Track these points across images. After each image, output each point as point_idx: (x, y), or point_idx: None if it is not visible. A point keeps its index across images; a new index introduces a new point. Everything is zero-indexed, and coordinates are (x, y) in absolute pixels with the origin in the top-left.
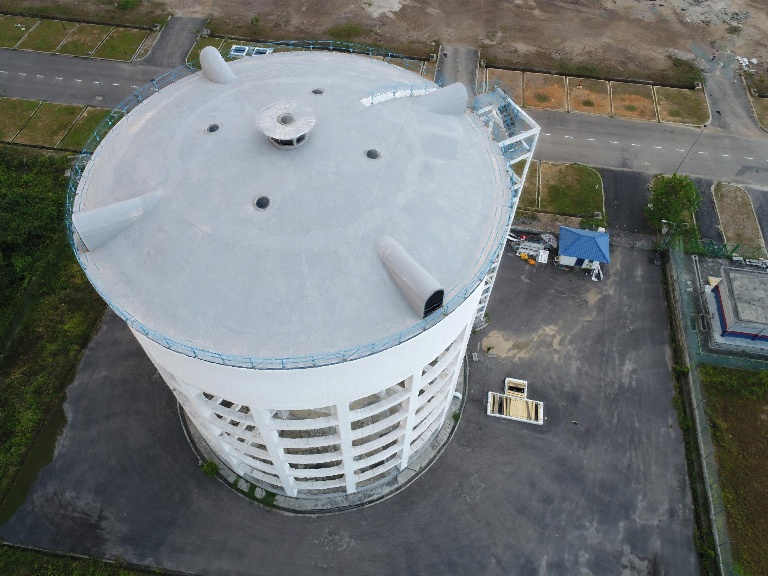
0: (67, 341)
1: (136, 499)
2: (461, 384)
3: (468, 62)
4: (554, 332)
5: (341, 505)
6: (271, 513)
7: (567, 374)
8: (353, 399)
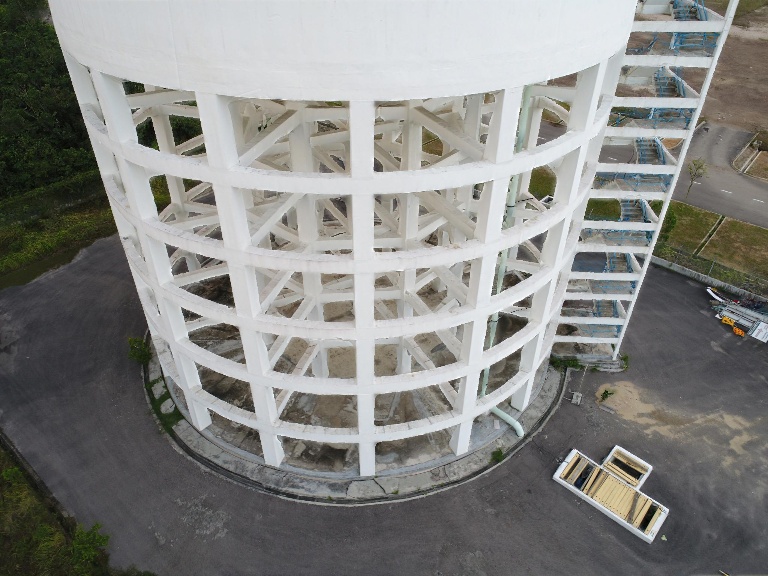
0: None
1: (51, 349)
2: (532, 419)
3: (735, 140)
4: (740, 427)
5: (247, 474)
6: (160, 436)
7: (741, 494)
8: (223, 89)
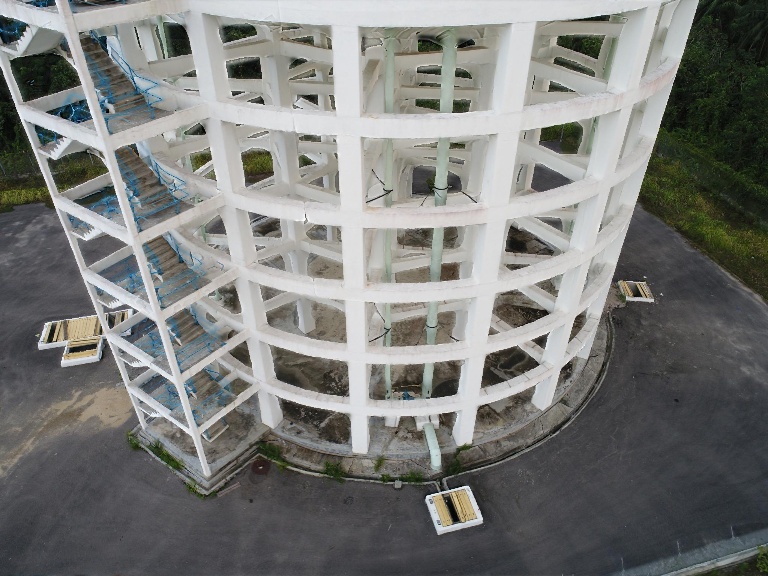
0: (701, 224)
1: None
2: None
3: None
4: None
5: None
6: None
7: None
8: None
